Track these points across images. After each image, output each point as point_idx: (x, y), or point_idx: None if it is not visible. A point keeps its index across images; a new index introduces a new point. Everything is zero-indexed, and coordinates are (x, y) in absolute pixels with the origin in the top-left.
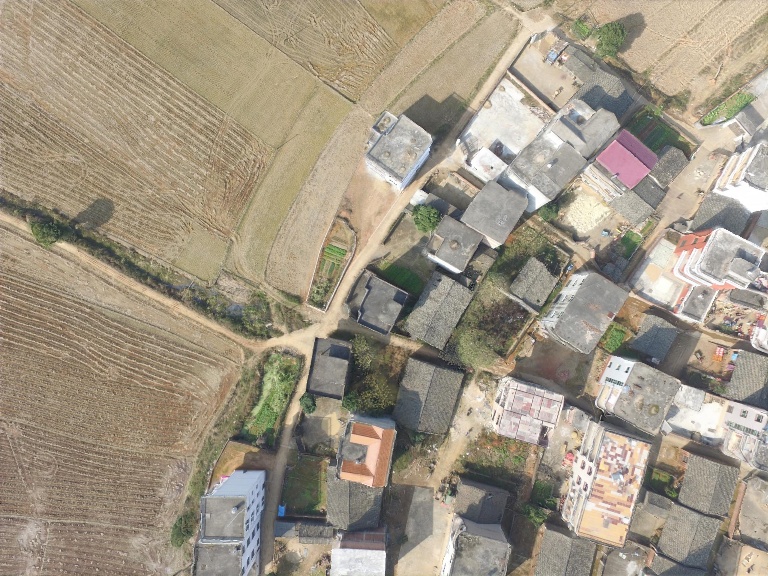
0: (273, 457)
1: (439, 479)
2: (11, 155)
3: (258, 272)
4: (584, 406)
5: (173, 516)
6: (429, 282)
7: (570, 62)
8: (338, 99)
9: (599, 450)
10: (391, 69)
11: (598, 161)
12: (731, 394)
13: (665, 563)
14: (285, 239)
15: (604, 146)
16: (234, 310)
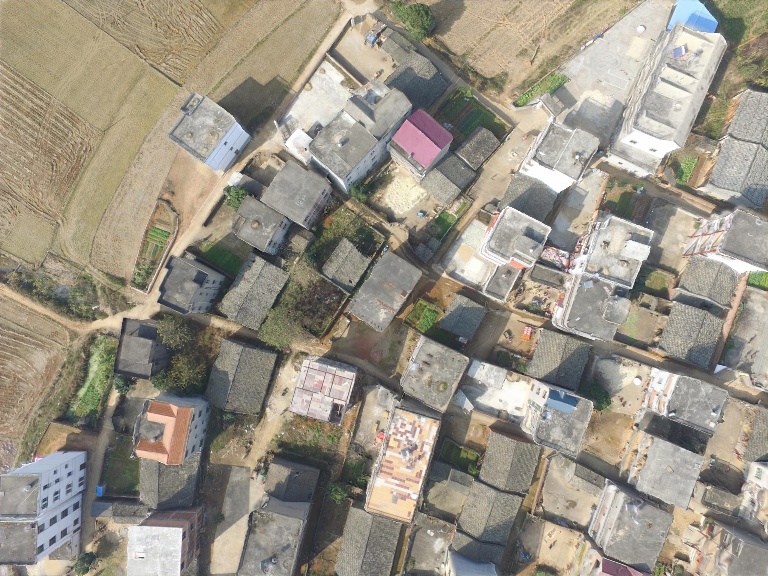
0: (95, 438)
1: (255, 459)
2: None
3: (84, 255)
4: (393, 385)
5: None
6: (244, 263)
7: (386, 44)
8: (164, 82)
9: (389, 427)
10: (216, 52)
11: (395, 141)
12: (532, 372)
13: (463, 539)
14: (110, 222)
15: (397, 126)
16: (61, 293)
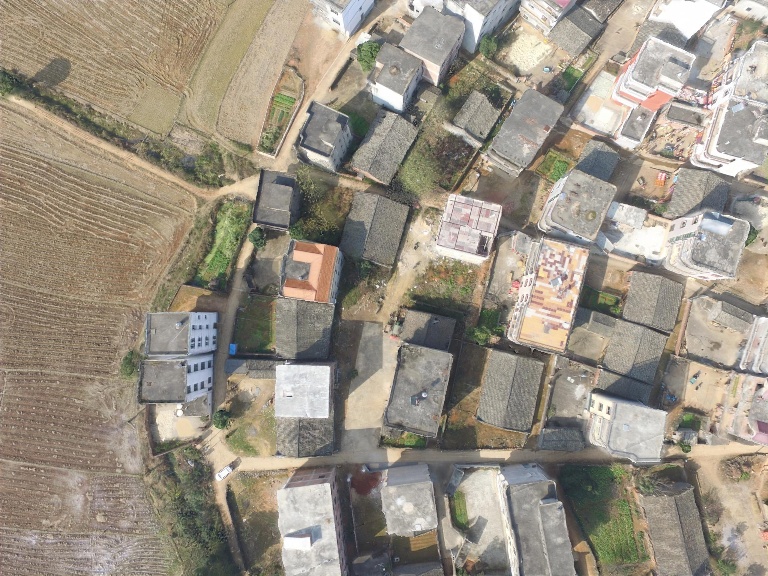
0: (225, 300)
1: (388, 314)
2: None
3: (210, 124)
4: (528, 232)
5: None
6: (374, 120)
7: None
8: None
9: (538, 257)
10: None
11: None
12: (672, 211)
13: (610, 377)
14: (236, 91)
15: None
16: (187, 162)
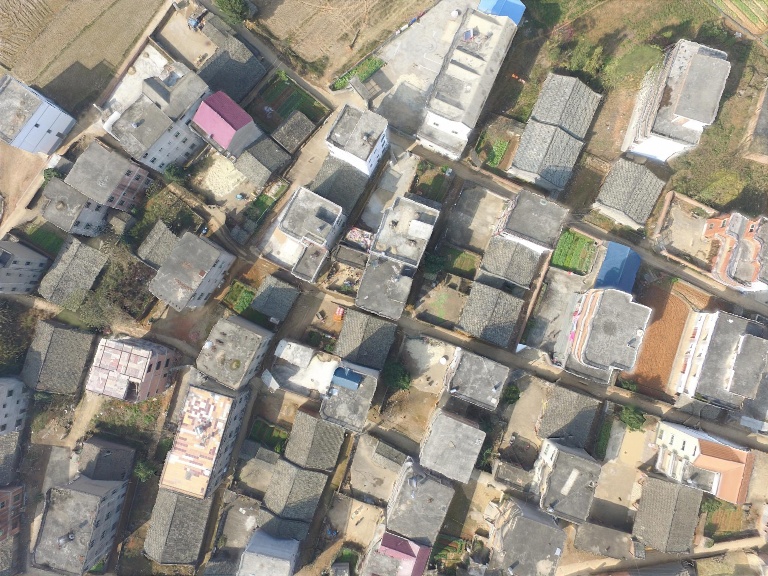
0: None
1: (75, 439)
2: None
3: None
4: None
5: None
6: (63, 245)
7: (206, 28)
8: None
9: (183, 404)
10: (45, 36)
11: (195, 123)
12: (337, 351)
13: (266, 516)
14: None
15: (194, 107)
16: None
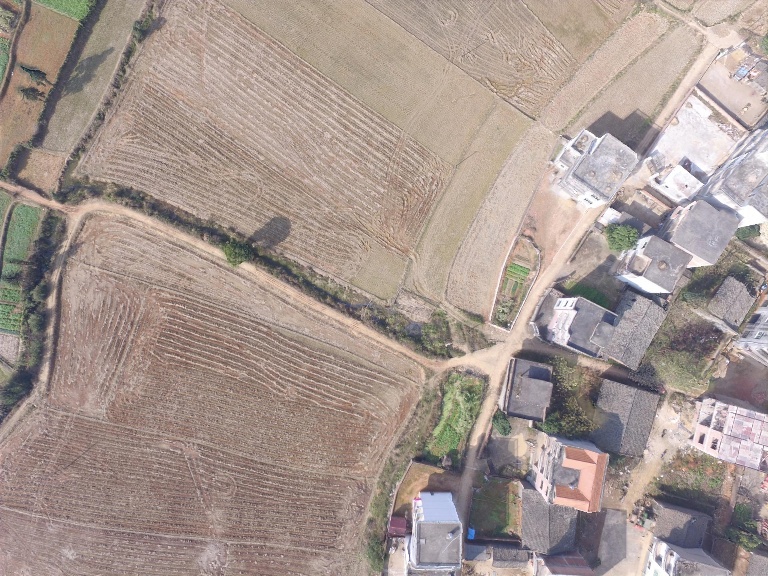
0: (458, 479)
1: (632, 502)
2: (186, 173)
3: (438, 291)
4: None
5: (354, 538)
6: (622, 302)
7: (762, 78)
8: (517, 116)
9: None
10: (571, 85)
11: None
12: None
13: None
14: (466, 257)
15: None
16: (413, 329)
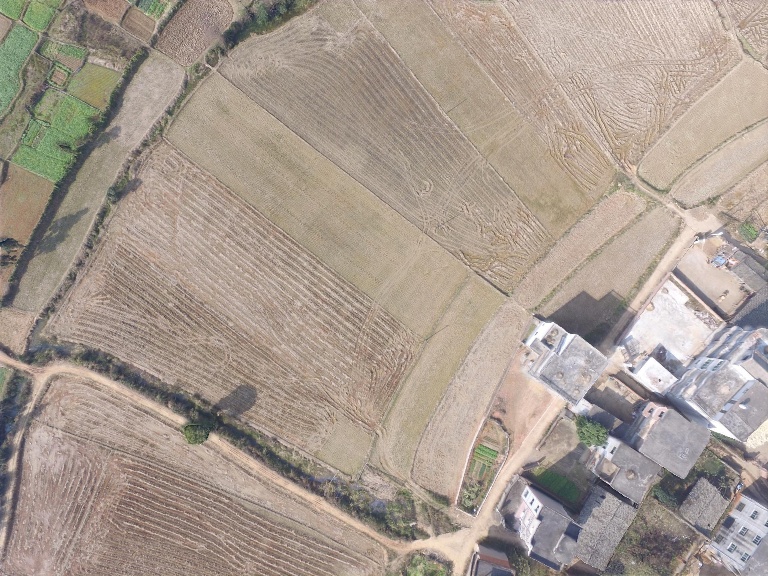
0: None
1: None
2: (154, 336)
3: (404, 469)
4: None
5: None
6: (591, 497)
7: (740, 269)
8: (490, 290)
9: None
10: (546, 262)
11: None
12: None
13: None
14: (433, 436)
15: None
16: (377, 507)
